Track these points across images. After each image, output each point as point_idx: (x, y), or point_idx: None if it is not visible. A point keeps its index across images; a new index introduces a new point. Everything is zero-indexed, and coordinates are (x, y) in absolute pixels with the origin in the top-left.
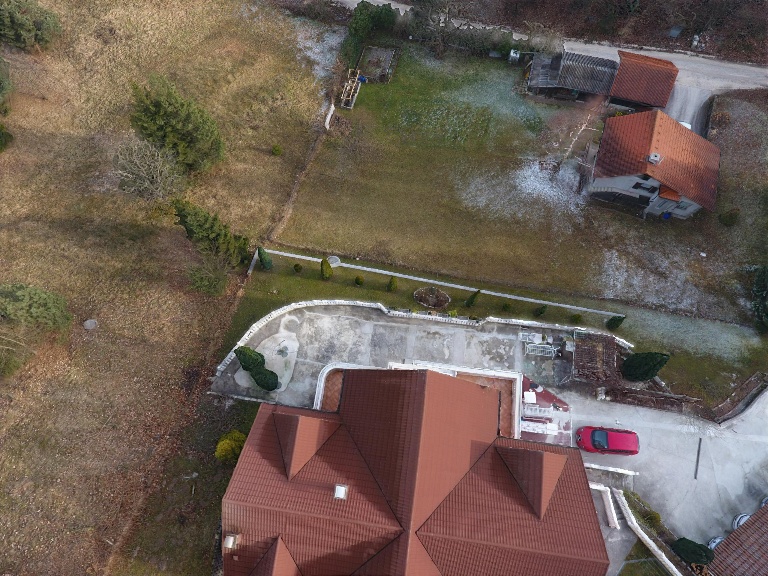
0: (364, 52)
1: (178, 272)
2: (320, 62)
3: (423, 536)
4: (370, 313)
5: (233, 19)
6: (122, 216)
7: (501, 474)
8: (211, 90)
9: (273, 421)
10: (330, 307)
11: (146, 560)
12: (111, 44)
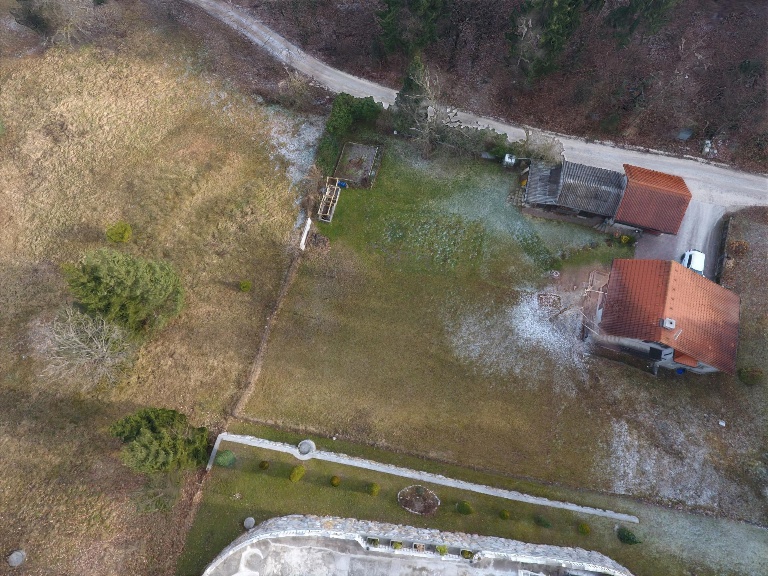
0: (344, 149)
1: (126, 467)
2: (295, 162)
3: None
4: (346, 542)
5: (199, 108)
6: (64, 388)
7: None
8: (172, 205)
9: None
10: (299, 536)
11: None
12: (62, 143)
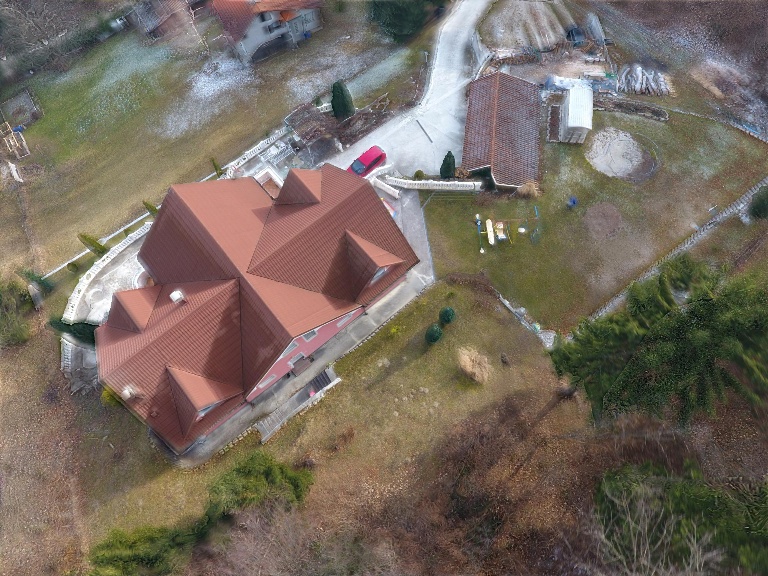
0: (2, 111)
1: None
2: None
3: (254, 270)
4: None
5: None
6: None
7: (285, 210)
8: None
9: (110, 328)
10: (115, 260)
11: (109, 508)
12: None
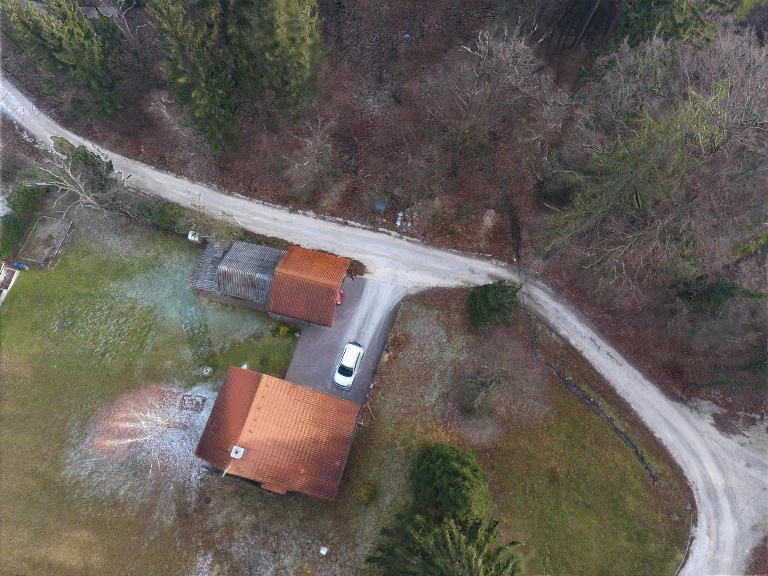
0: (36, 225)
1: None
2: None
3: None
4: None
5: None
6: None
7: None
8: None
9: None
10: None
11: None
12: None
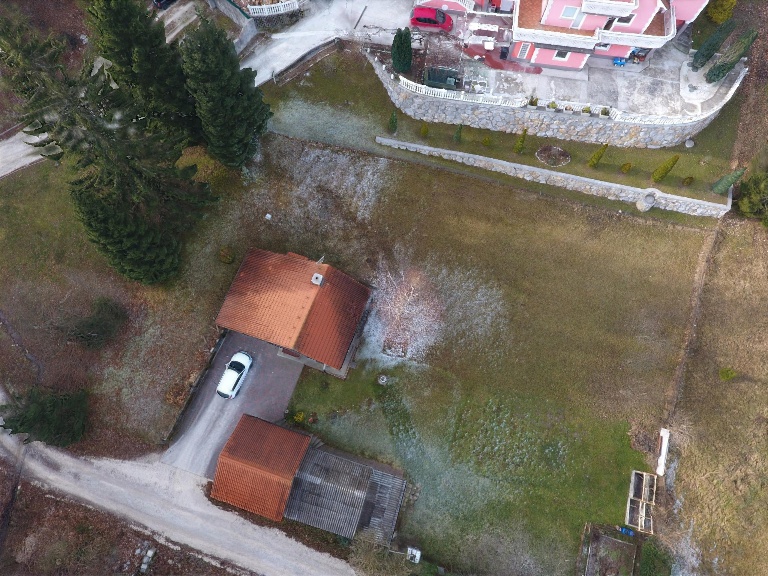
0: None
1: None
2: (691, 574)
3: None
4: None
5: None
6: None
7: None
8: None
9: None
10: None
11: None
12: None
